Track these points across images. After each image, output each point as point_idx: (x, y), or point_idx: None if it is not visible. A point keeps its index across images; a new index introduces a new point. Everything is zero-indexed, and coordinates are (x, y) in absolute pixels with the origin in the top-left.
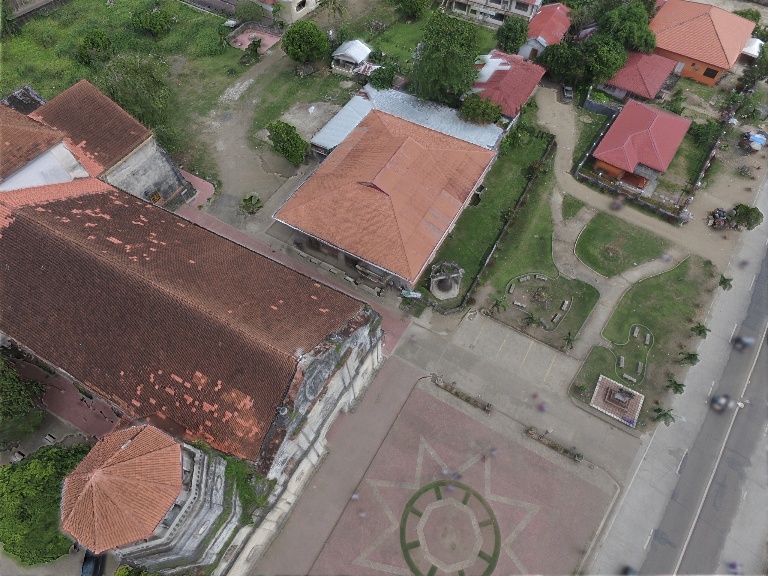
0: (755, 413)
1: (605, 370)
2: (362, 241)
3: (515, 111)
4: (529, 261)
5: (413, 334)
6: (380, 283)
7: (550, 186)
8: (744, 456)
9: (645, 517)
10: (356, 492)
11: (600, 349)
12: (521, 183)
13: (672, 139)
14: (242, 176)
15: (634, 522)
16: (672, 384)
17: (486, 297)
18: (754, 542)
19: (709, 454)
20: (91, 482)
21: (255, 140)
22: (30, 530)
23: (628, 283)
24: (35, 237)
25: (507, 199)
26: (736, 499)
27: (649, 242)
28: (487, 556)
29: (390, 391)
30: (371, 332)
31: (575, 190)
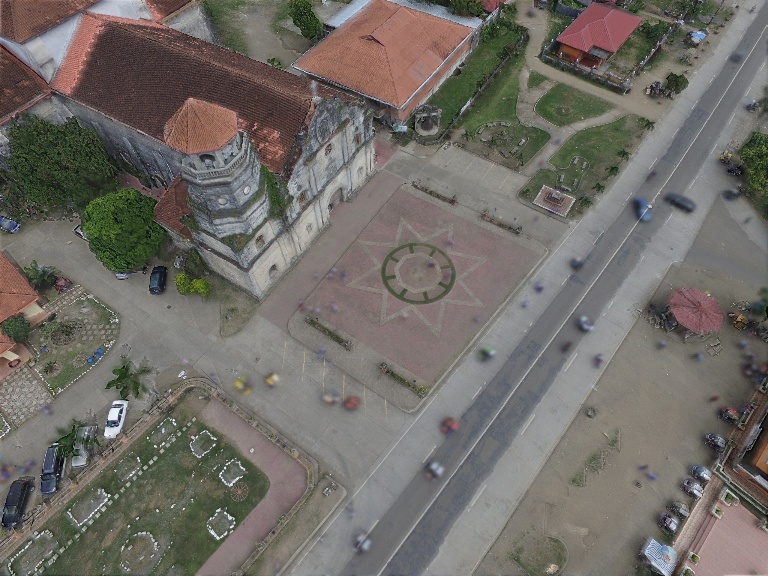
0: (660, 212)
1: (548, 183)
2: (362, 80)
3: (495, 7)
4: (497, 114)
5: (399, 157)
6: (375, 117)
7: (520, 65)
8: (646, 236)
9: (565, 268)
10: (350, 247)
11: (546, 171)
12: (496, 62)
13: (624, 29)
14: (265, 51)
15: (556, 270)
16: (596, 186)
17: (459, 136)
18: (644, 284)
19: (620, 234)
20: (187, 103)
21: (276, 27)
22: (118, 233)
23: (575, 130)
24: (119, 39)
25: (483, 73)
26: (635, 260)
27: (596, 104)
28: (445, 285)
29: (379, 191)
30: (365, 121)
31: (540, 68)
